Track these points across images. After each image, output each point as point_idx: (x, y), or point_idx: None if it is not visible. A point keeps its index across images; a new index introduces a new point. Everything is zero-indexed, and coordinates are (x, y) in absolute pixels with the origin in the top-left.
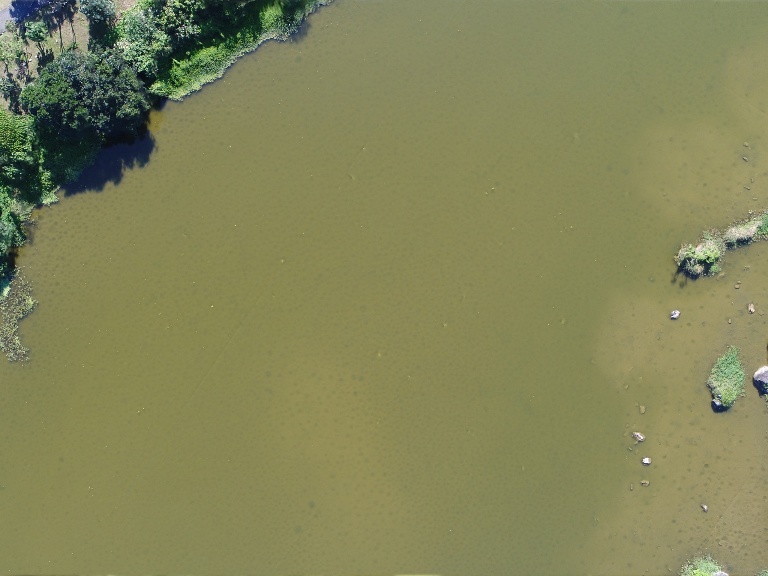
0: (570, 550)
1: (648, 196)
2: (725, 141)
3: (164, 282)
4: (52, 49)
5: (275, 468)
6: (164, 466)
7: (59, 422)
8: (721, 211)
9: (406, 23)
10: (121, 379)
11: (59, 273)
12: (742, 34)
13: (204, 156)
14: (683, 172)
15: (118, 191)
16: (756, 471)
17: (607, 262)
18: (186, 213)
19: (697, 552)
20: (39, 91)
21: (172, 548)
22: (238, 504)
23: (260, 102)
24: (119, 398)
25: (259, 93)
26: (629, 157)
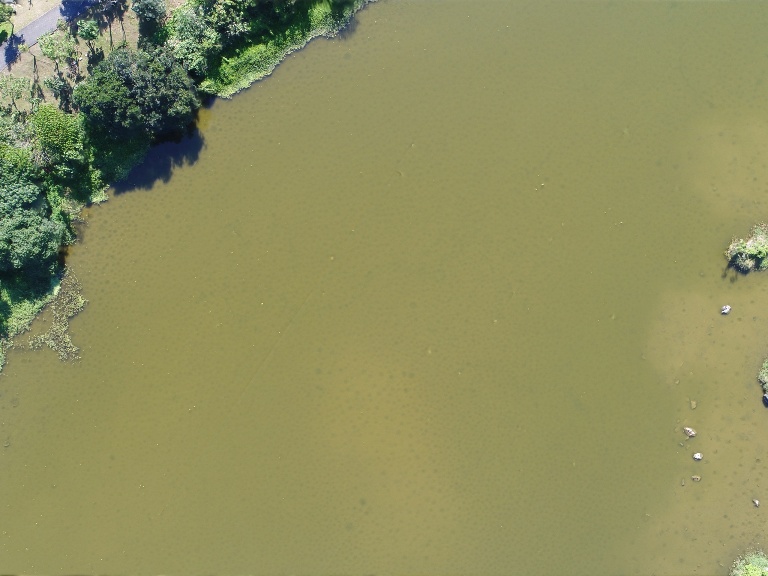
0: (621, 546)
1: (698, 191)
2: None
3: (214, 280)
4: (102, 47)
5: (326, 465)
6: (215, 464)
7: (110, 420)
8: None
9: (454, 19)
10: (171, 377)
11: (109, 271)
12: None
13: (253, 154)
14: (733, 167)
15: (167, 189)
16: None
17: (657, 257)
18: (235, 211)
19: (749, 547)
20: (92, 89)
21: (223, 546)
22: (289, 501)
23: (309, 99)
24: (170, 396)
25: (308, 90)
26: (679, 152)
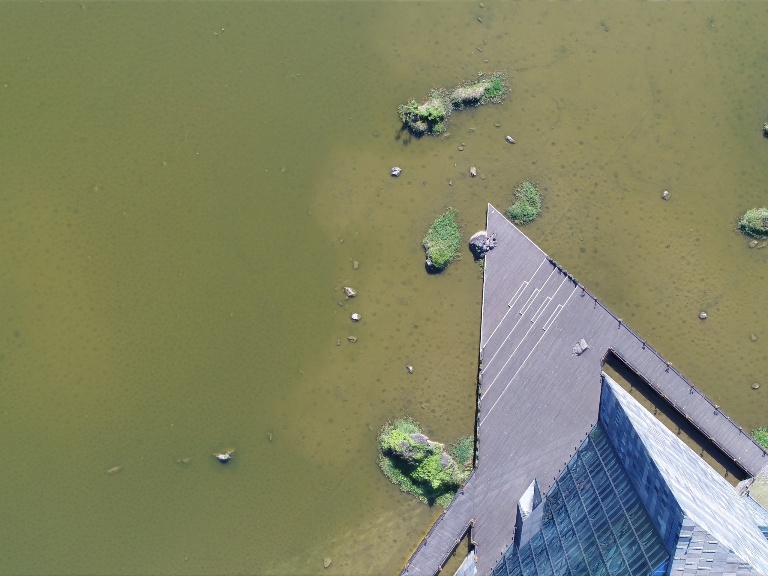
0: (273, 401)
1: (379, 50)
2: (461, 0)
3: None
4: None
5: None
6: None
7: None
8: (451, 71)
9: None
10: None
11: None
12: None
13: None
14: (416, 28)
15: None
16: (465, 336)
17: (332, 113)
18: None
19: (399, 413)
20: None
21: None
22: None
23: None
24: None
25: None
26: (363, 9)
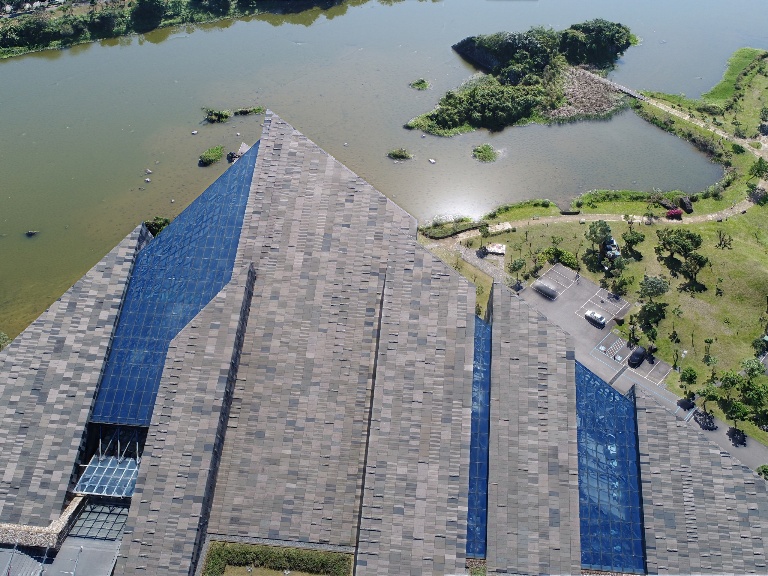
0: (78, 212)
1: None
2: None
3: None
4: None
5: None
6: None
7: None
8: (237, 105)
9: None
10: None
11: None
12: (272, 62)
13: None
14: None
15: None
16: None
17: None
18: None
19: None
20: None
21: None
22: None
23: None
24: None
25: None
26: (199, 88)
